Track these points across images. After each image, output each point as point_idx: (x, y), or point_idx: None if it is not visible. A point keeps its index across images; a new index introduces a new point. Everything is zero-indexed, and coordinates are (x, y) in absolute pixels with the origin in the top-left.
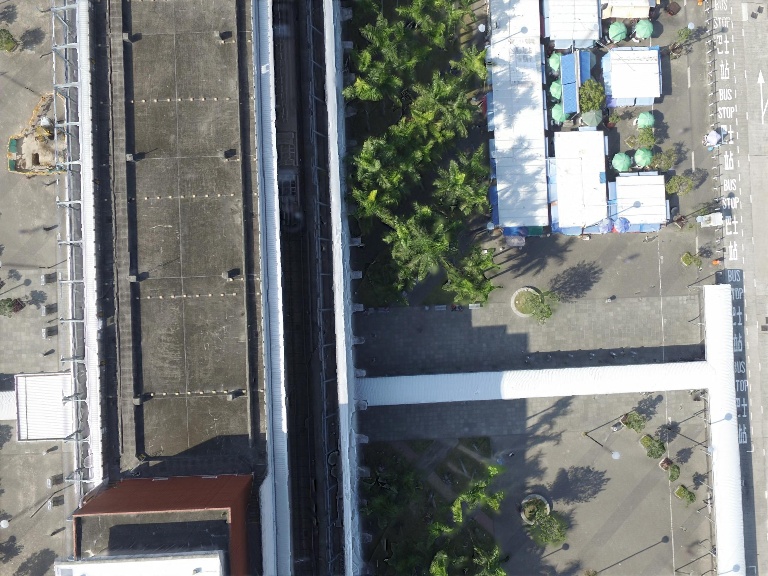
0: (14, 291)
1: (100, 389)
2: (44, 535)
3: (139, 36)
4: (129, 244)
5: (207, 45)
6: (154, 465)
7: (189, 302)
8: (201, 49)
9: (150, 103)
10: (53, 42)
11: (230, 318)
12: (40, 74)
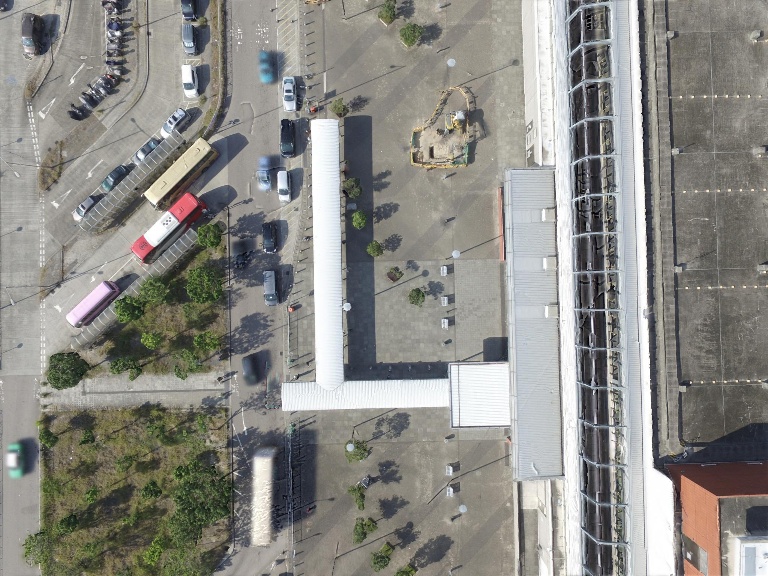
0: (412, 281)
1: (649, 376)
2: (441, 521)
3: (676, 34)
4: (672, 236)
5: (741, 44)
6: (699, 451)
7: (724, 293)
8: (735, 47)
9: (687, 99)
10: (583, 38)
11: (762, 309)
12: (437, 69)
